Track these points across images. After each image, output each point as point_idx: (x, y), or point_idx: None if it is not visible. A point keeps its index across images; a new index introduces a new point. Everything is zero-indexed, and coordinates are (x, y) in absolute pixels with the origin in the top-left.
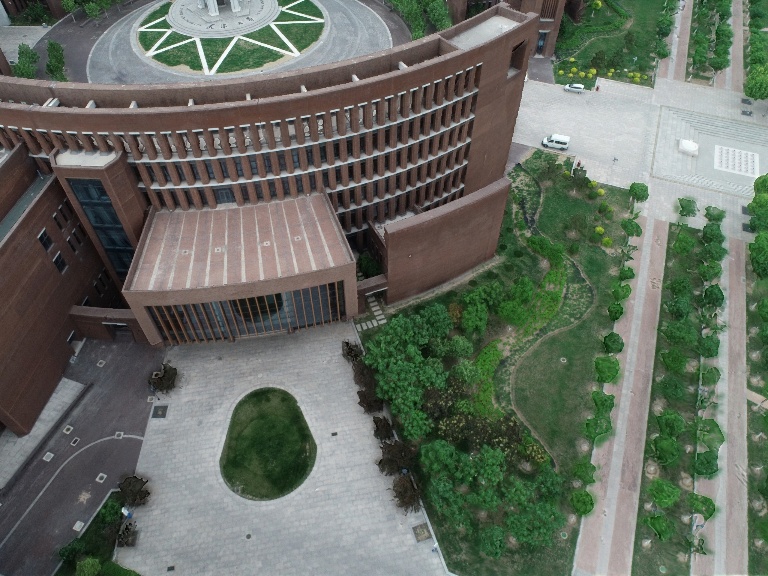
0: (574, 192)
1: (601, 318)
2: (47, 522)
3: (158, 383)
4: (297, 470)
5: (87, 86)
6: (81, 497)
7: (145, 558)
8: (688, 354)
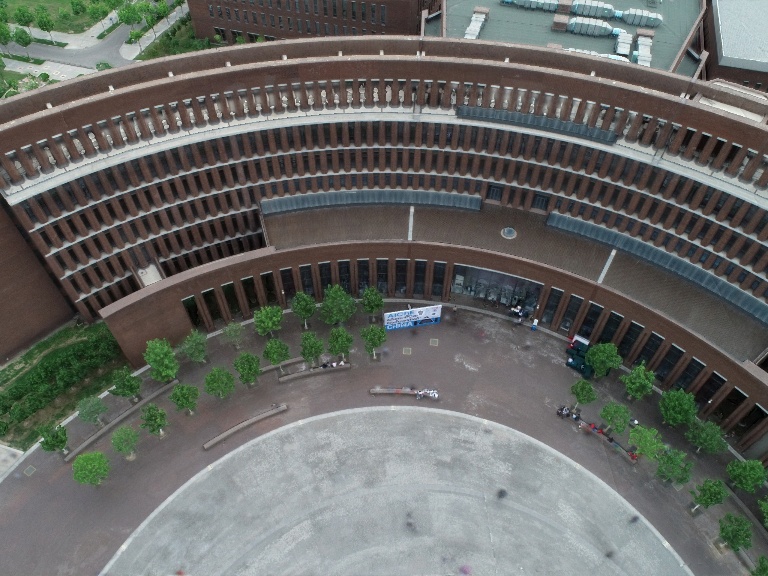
0: None
1: None
2: None
3: None
4: None
5: (384, 57)
6: None
7: None
8: None
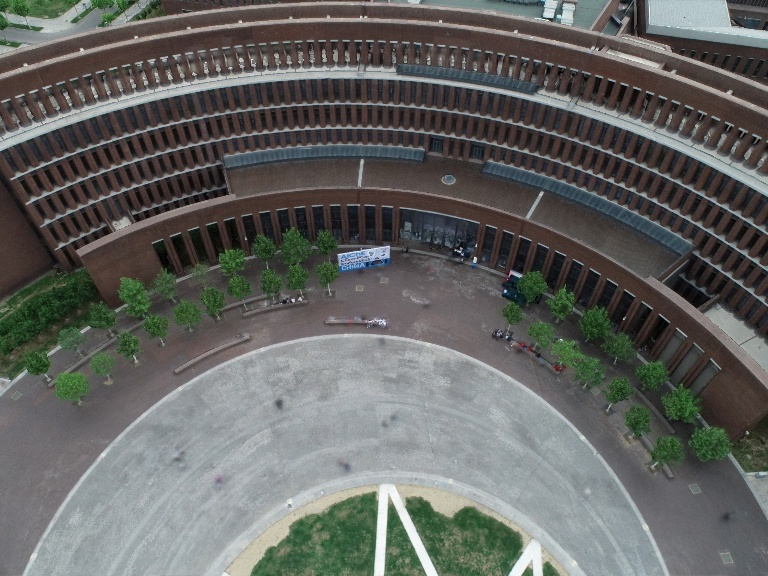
0: None
1: None
2: None
3: None
4: None
5: (329, 19)
6: None
7: None
8: None
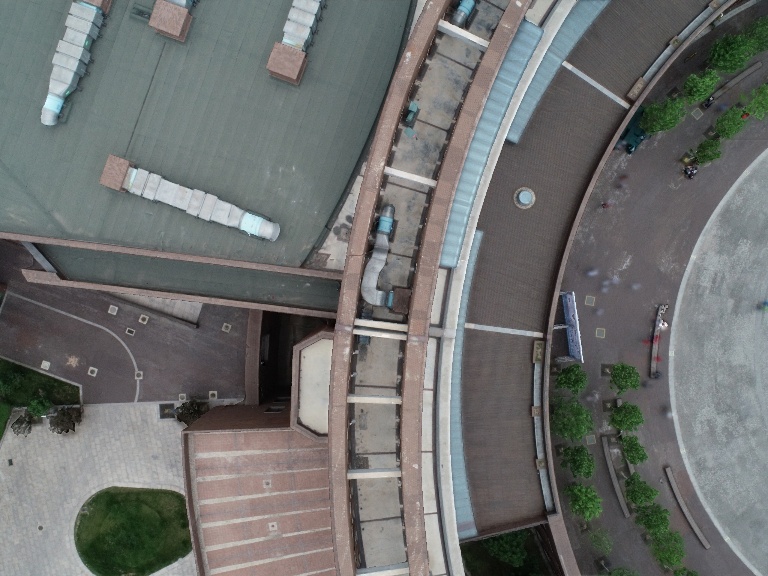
0: None
1: None
2: (48, 334)
3: (181, 416)
4: (104, 568)
5: (412, 403)
6: (73, 358)
7: (19, 437)
8: None
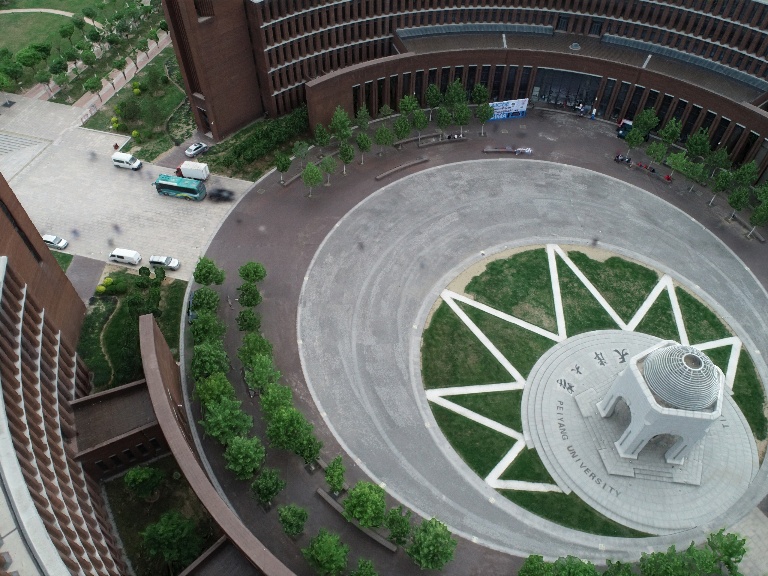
0: (138, 122)
1: (169, 52)
2: None
3: None
4: None
5: None
6: None
7: None
8: (127, 40)
